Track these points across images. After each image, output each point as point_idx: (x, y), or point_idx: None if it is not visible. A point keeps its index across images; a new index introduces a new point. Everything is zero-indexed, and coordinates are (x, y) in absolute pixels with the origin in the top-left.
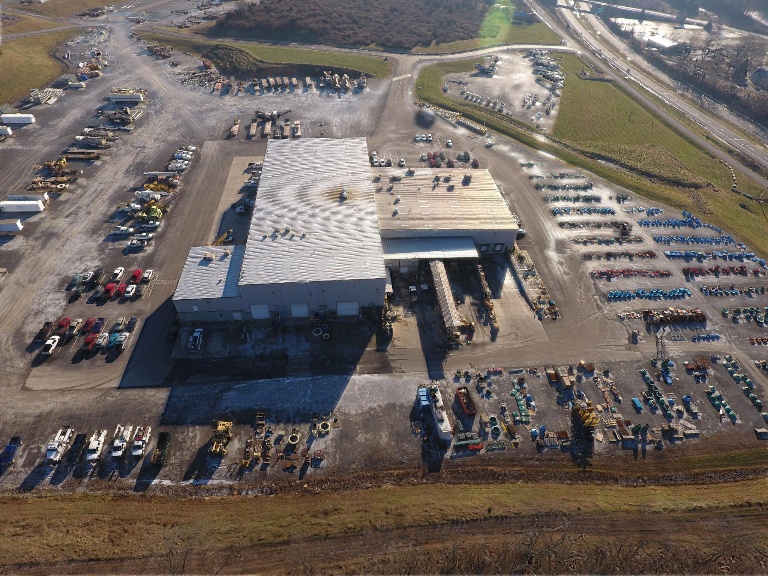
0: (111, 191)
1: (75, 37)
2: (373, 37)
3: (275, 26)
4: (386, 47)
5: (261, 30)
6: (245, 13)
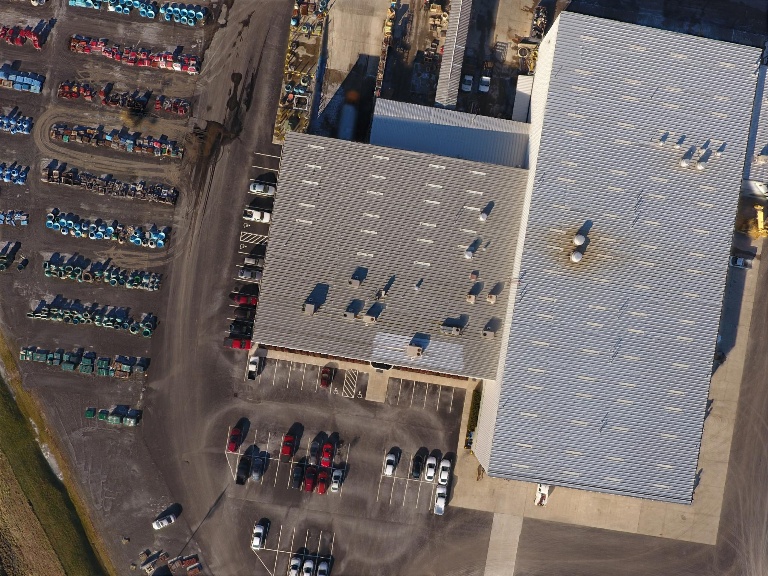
0: None
1: None
2: None
3: None
4: None
5: None
6: None
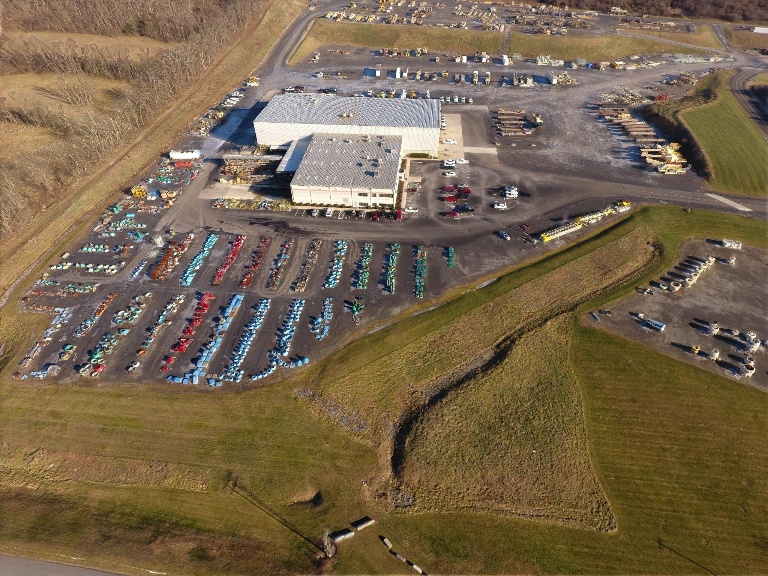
0: None
1: None
2: None
3: None
4: None
5: None
6: None
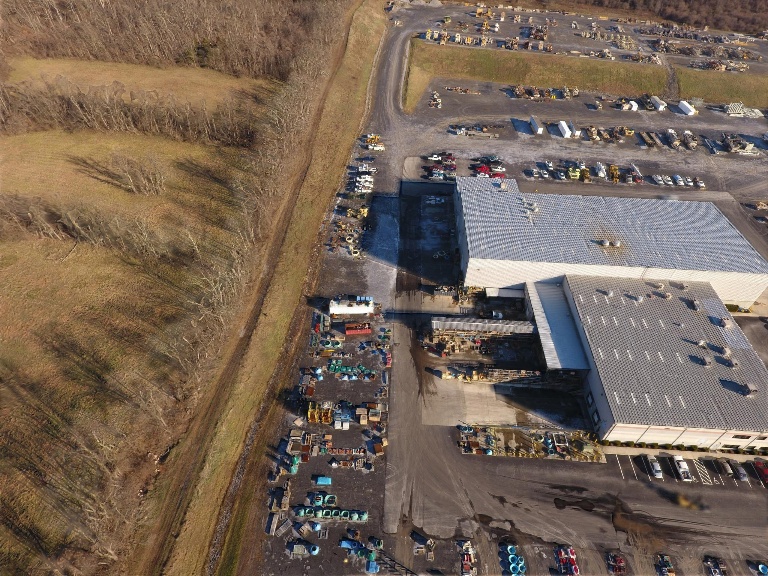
0: (604, 157)
1: None
2: None
3: None
4: None
5: None
6: None
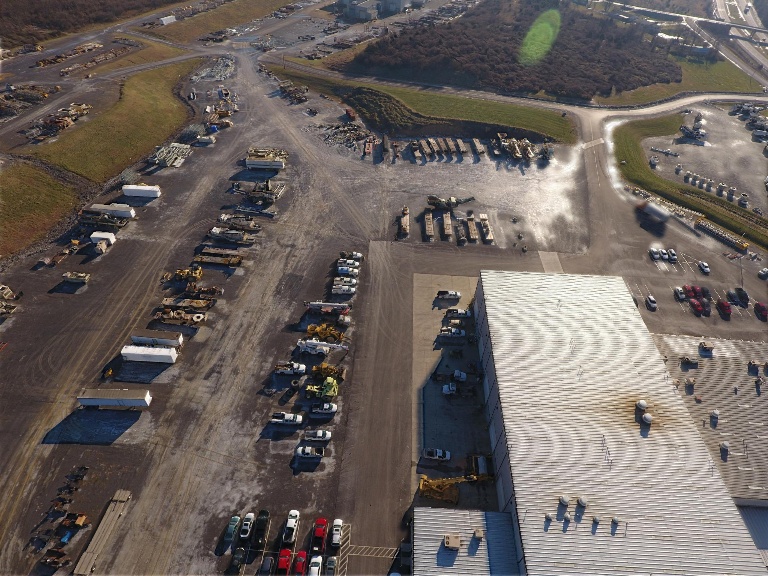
0: (261, 328)
1: (200, 70)
2: (541, 82)
3: (425, 65)
4: (559, 96)
5: (408, 69)
6: (388, 46)
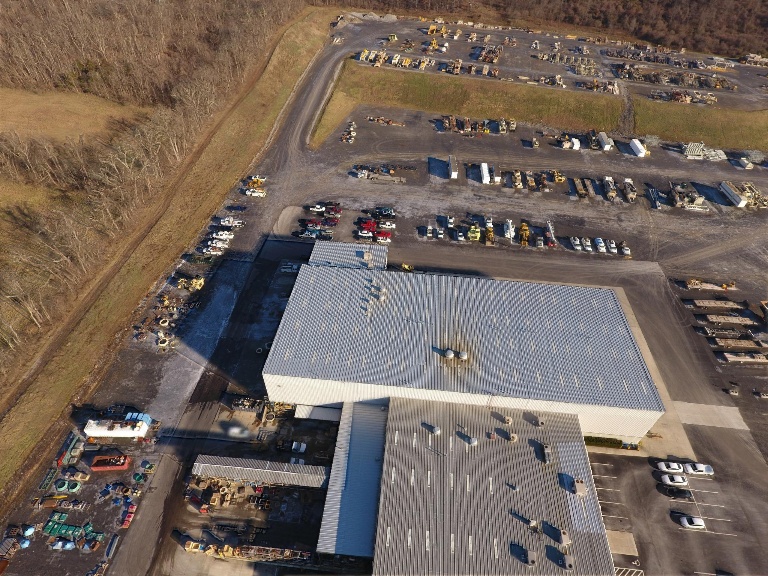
0: (521, 211)
1: None
2: None
3: None
4: None
5: None
6: None
